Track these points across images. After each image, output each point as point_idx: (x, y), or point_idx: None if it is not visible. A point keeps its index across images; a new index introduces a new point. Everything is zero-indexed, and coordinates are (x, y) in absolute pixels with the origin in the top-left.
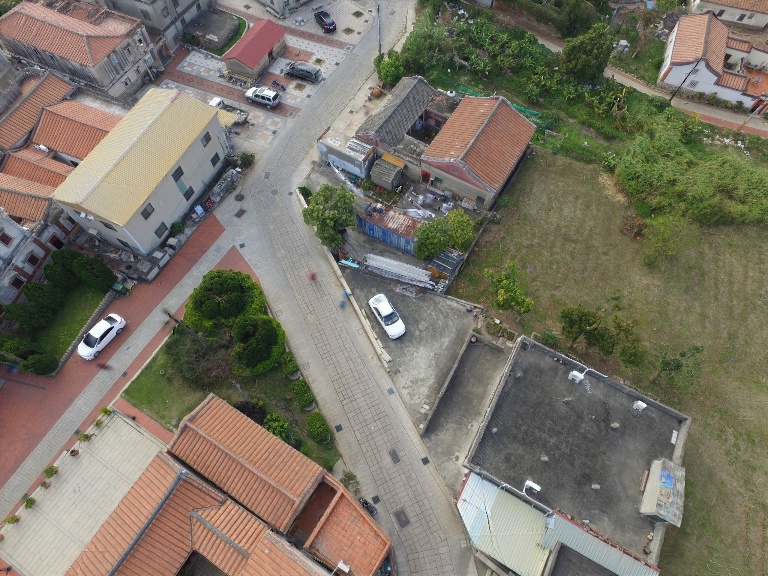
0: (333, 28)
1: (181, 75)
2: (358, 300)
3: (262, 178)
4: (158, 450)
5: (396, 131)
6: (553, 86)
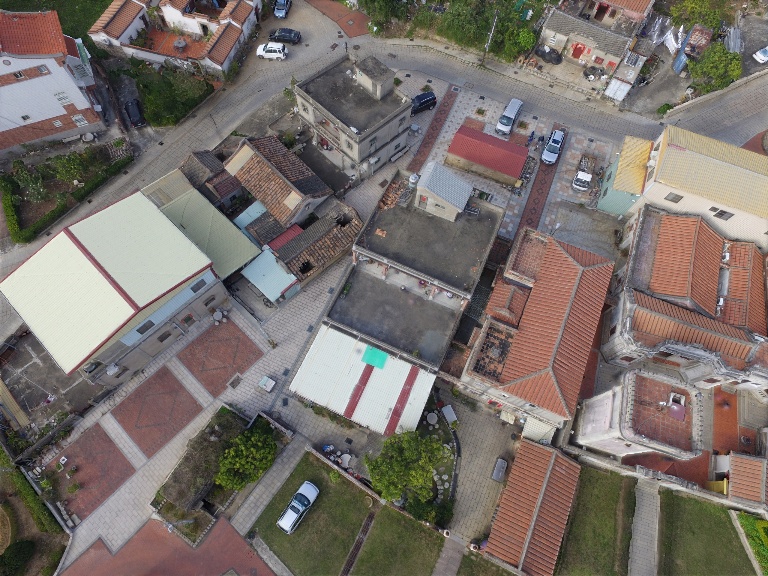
0: None
1: None
2: (759, 71)
3: None
4: None
5: None
6: None
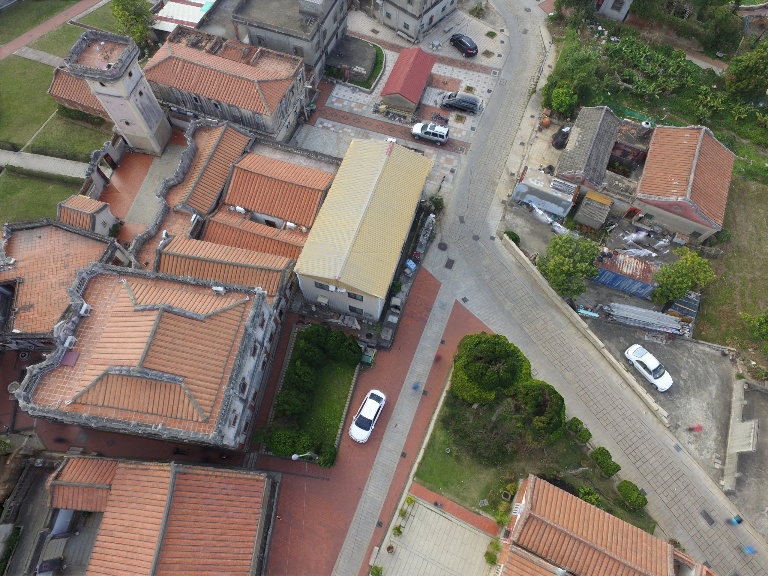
0: (475, 52)
1: (334, 112)
2: (611, 352)
3: (458, 223)
4: (473, 536)
5: (598, 167)
6: (720, 106)
